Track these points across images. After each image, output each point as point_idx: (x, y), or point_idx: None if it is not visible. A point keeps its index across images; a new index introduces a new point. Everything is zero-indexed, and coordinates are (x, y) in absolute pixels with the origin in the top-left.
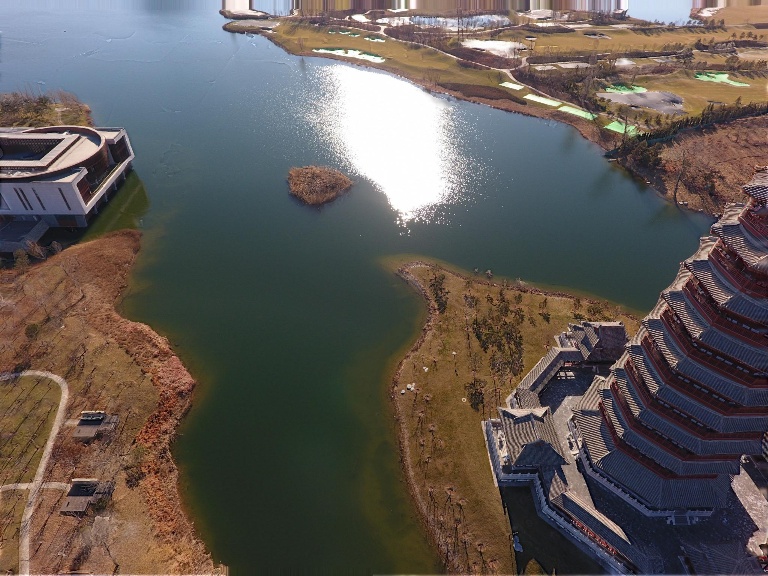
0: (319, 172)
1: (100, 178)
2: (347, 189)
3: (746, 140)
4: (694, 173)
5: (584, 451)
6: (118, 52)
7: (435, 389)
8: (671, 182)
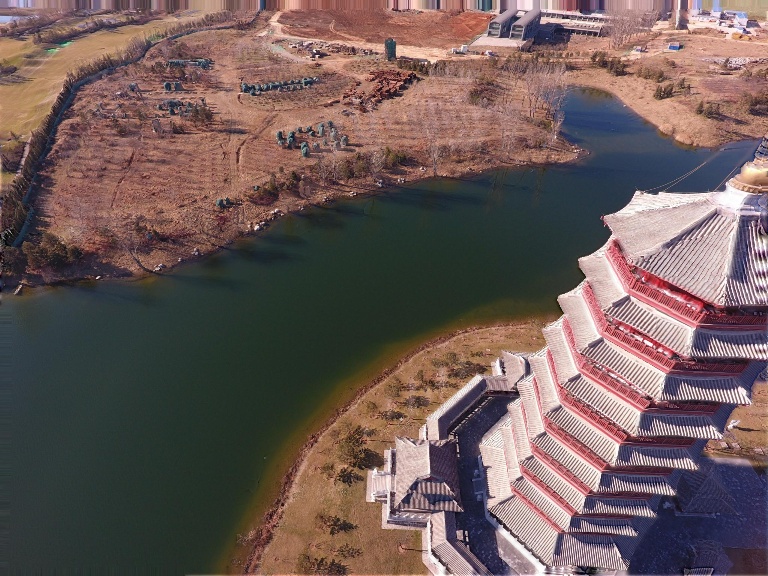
0: None
1: None
2: None
3: (89, 169)
4: (118, 233)
5: (592, 570)
6: None
7: None
8: (116, 259)
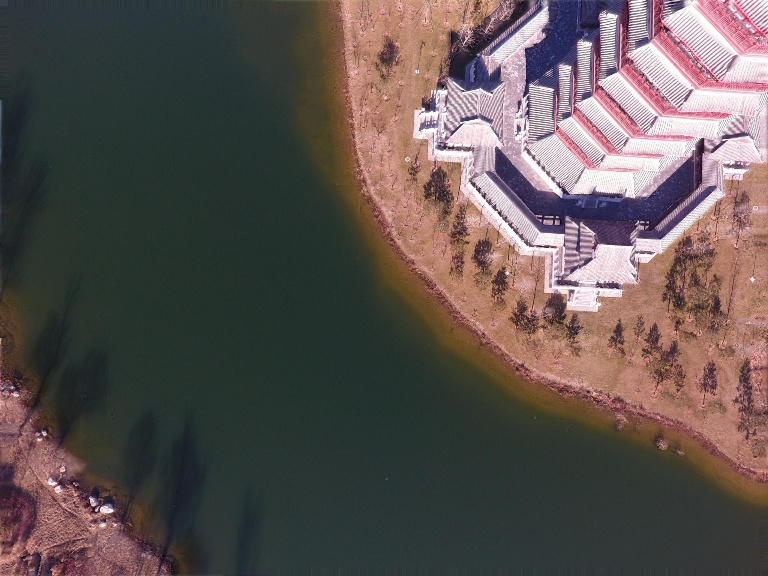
0: None
1: None
2: None
3: None
4: None
5: None
6: None
7: None
8: None
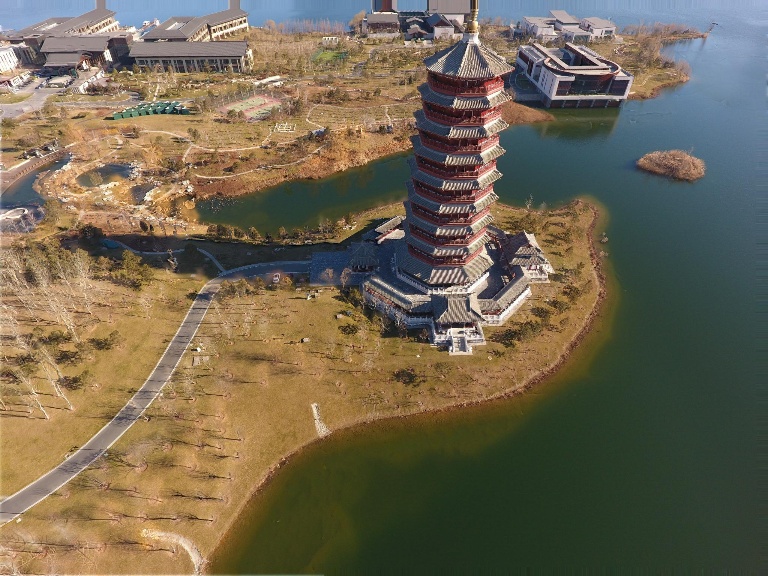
0: (685, 160)
1: None
2: (679, 179)
3: None
4: None
5: None
6: None
7: None
8: None
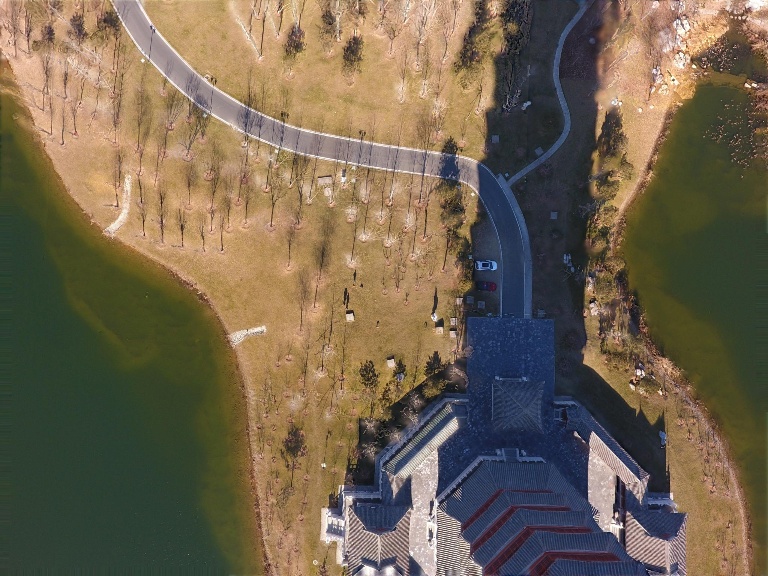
0: None
1: None
2: None
3: None
4: None
5: None
6: None
7: None
8: None
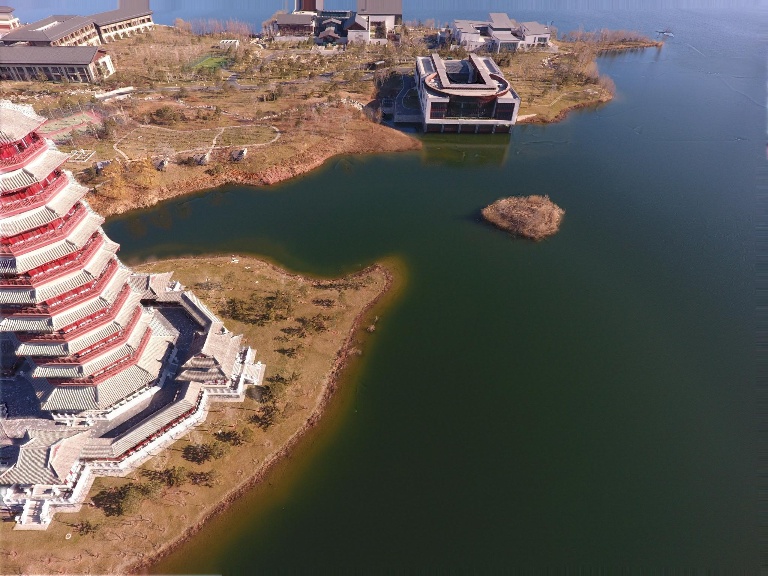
0: (539, 210)
1: (468, 116)
2: (524, 236)
3: None
4: None
5: None
6: (756, 86)
7: (225, 268)
8: None
